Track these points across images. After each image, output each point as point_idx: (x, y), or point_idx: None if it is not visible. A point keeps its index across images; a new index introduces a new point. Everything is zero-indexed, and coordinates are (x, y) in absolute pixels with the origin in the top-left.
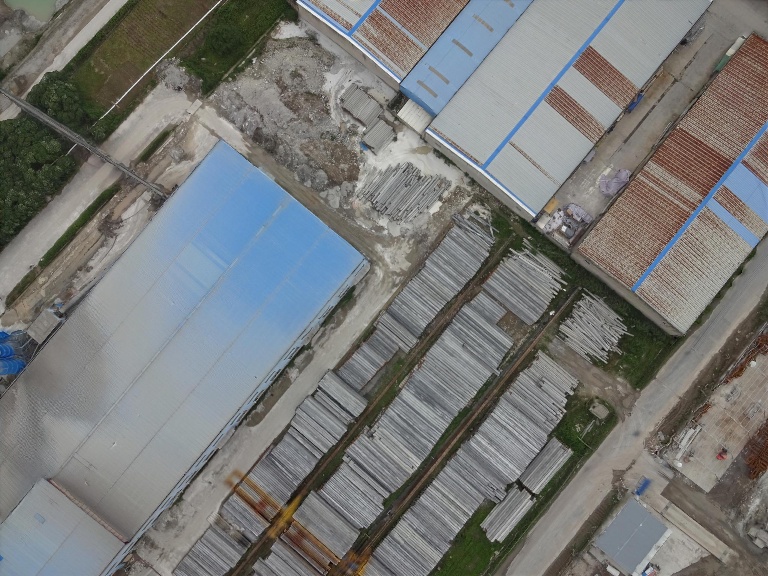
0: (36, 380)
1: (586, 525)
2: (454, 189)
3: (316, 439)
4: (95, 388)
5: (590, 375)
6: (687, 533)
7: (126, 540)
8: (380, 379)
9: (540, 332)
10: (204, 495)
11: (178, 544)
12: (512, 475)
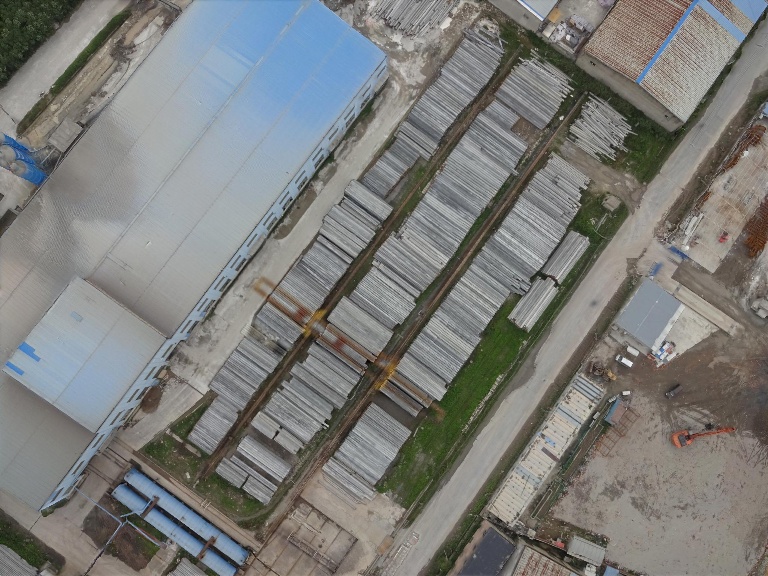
0: (62, 187)
1: (606, 311)
2: (462, 6)
3: (346, 244)
4: (125, 189)
5: (600, 173)
6: (697, 311)
7: (167, 336)
8: (403, 187)
9: (552, 135)
10: (236, 308)
11: (213, 358)
12: (536, 265)
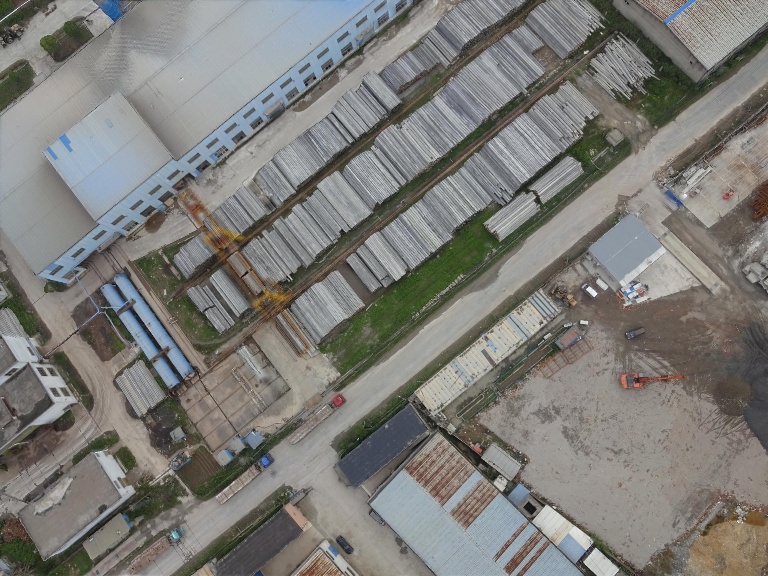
0: (131, 24)
1: (584, 239)
2: None
3: (351, 125)
4: (176, 33)
5: (612, 109)
6: (681, 261)
7: (174, 157)
8: (418, 87)
9: (572, 66)
10: (244, 162)
11: (214, 199)
12: (521, 177)
